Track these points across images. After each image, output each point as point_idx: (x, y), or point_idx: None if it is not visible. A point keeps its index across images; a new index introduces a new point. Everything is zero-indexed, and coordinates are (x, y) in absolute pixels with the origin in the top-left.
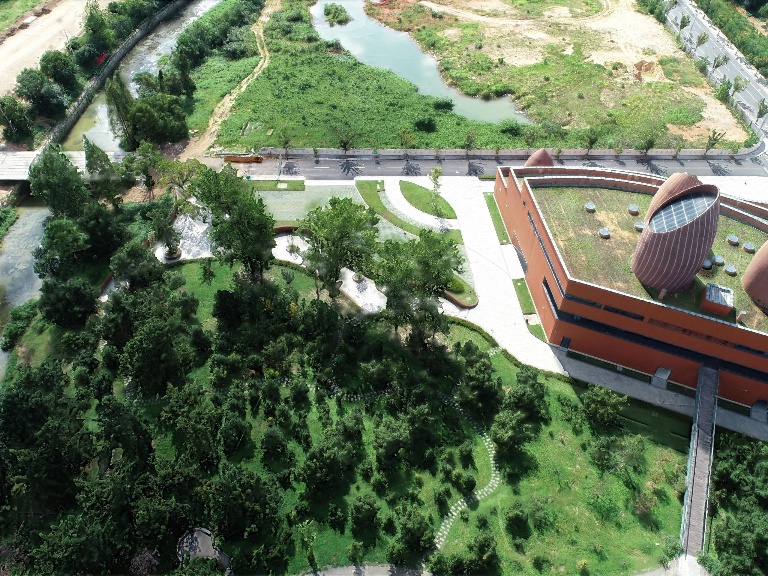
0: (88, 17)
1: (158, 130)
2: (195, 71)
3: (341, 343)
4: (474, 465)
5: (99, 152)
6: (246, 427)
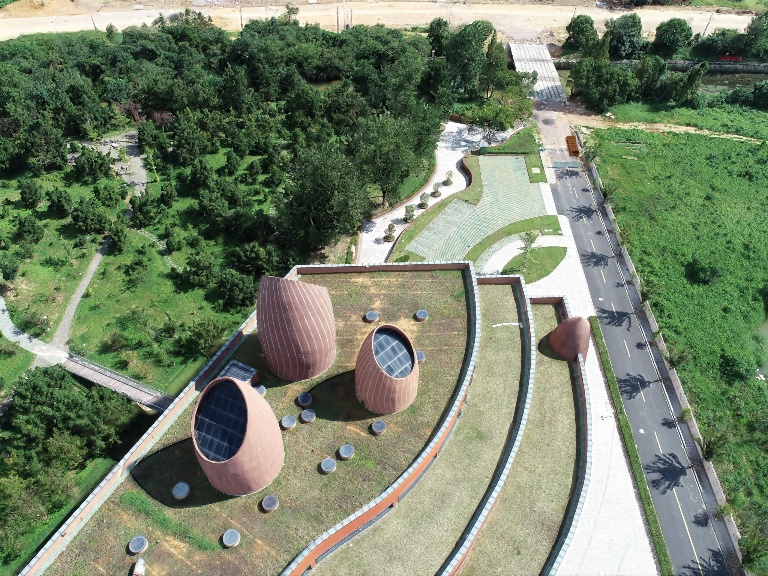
0: (753, 19)
1: (579, 87)
2: (741, 108)
3: None
4: None
5: (498, 50)
6: (240, 146)
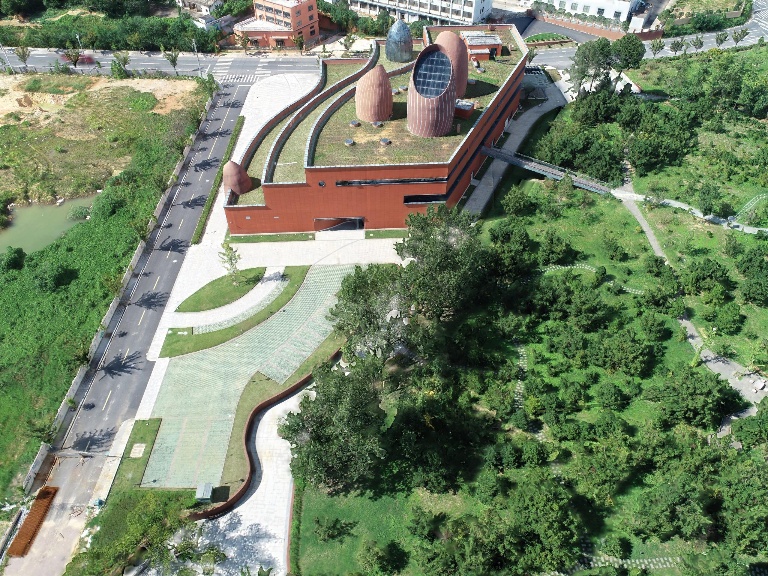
0: None
1: None
2: None
3: (474, 352)
4: (576, 276)
5: None
6: None
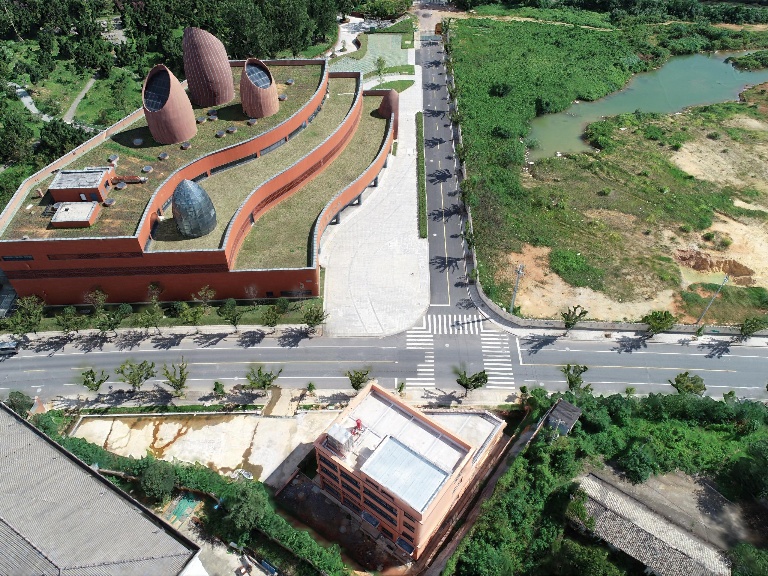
0: None
1: None
2: (575, 9)
3: None
4: None
5: None
6: None
